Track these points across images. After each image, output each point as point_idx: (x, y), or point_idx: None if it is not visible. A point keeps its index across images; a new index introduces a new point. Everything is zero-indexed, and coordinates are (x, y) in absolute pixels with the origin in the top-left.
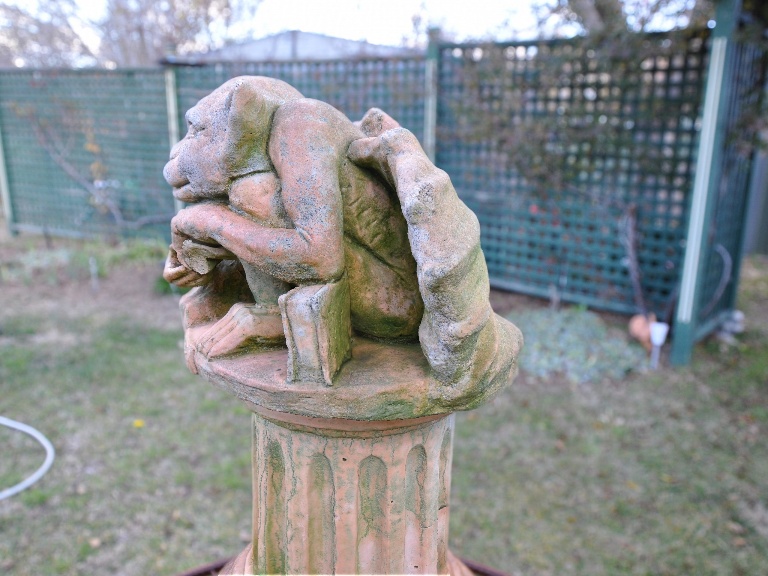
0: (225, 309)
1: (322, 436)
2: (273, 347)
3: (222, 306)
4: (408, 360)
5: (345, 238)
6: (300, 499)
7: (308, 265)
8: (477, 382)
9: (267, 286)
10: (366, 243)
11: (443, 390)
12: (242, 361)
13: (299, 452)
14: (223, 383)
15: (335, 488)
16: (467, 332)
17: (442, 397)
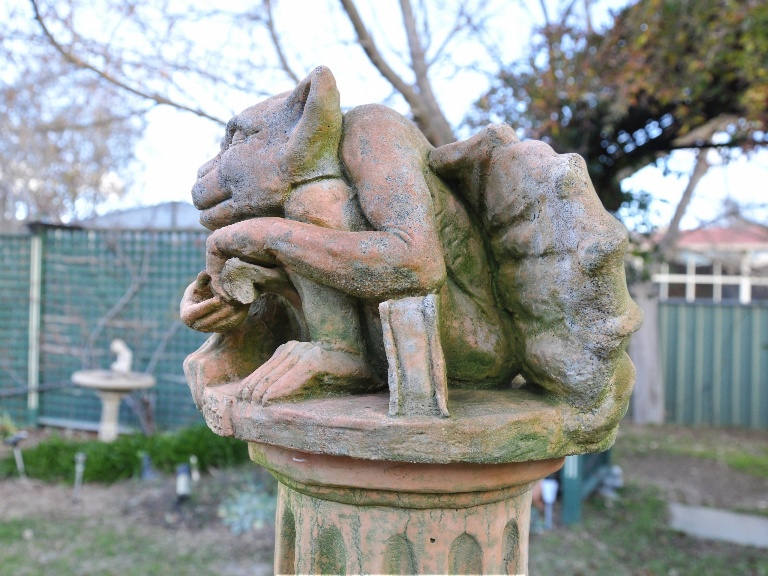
0: (246, 368)
1: (402, 509)
2: (338, 392)
3: (243, 364)
4: (514, 397)
5: None
6: None
7: (408, 269)
8: (621, 405)
9: (333, 314)
10: (448, 264)
11: (581, 419)
12: (311, 403)
13: (369, 536)
14: (286, 433)
15: None
16: (629, 328)
17: (580, 428)
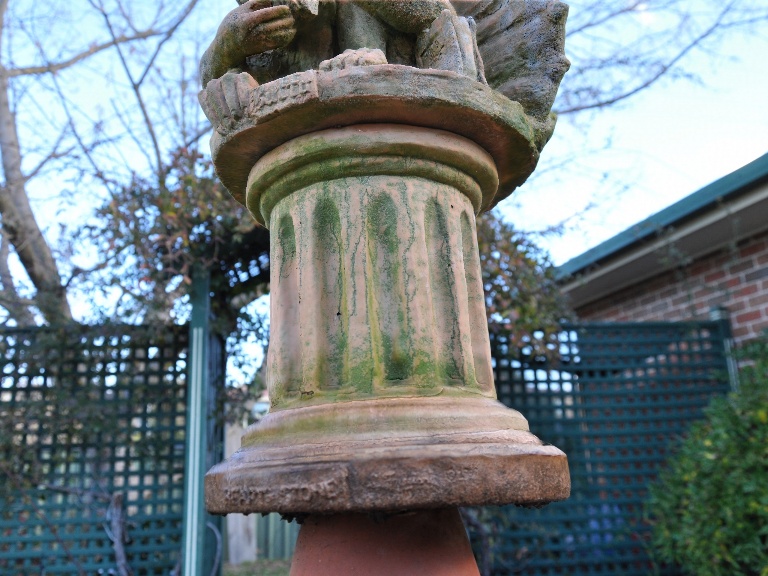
0: None
1: (433, 181)
2: None
3: None
4: None
5: None
6: (420, 246)
7: (444, 7)
8: None
9: (375, 41)
10: None
11: (539, 124)
12: None
13: (414, 197)
14: (383, 84)
15: (449, 233)
16: None
17: (539, 129)
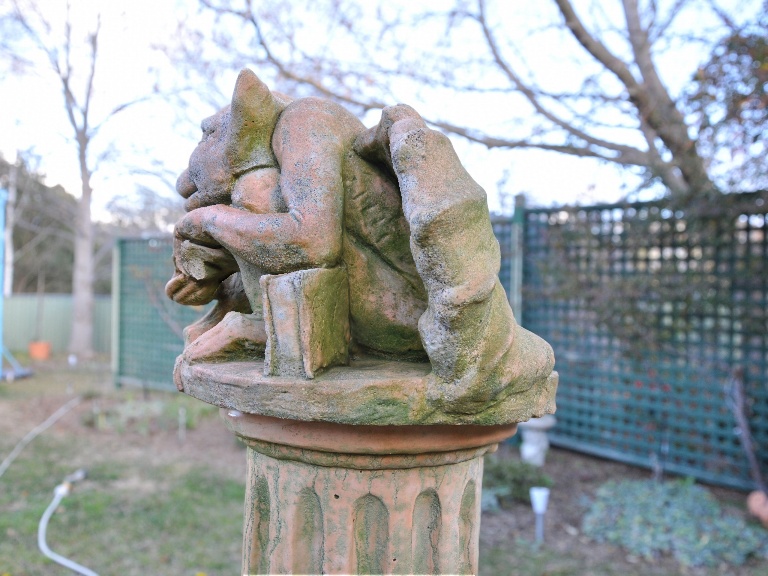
0: None
1: (312, 466)
2: (264, 357)
3: None
4: (411, 368)
5: (349, 236)
6: (284, 549)
7: (297, 246)
8: (485, 377)
9: None
10: (372, 242)
11: (444, 388)
12: (224, 364)
13: (286, 487)
14: (201, 388)
15: (324, 534)
16: (464, 298)
17: (443, 398)
